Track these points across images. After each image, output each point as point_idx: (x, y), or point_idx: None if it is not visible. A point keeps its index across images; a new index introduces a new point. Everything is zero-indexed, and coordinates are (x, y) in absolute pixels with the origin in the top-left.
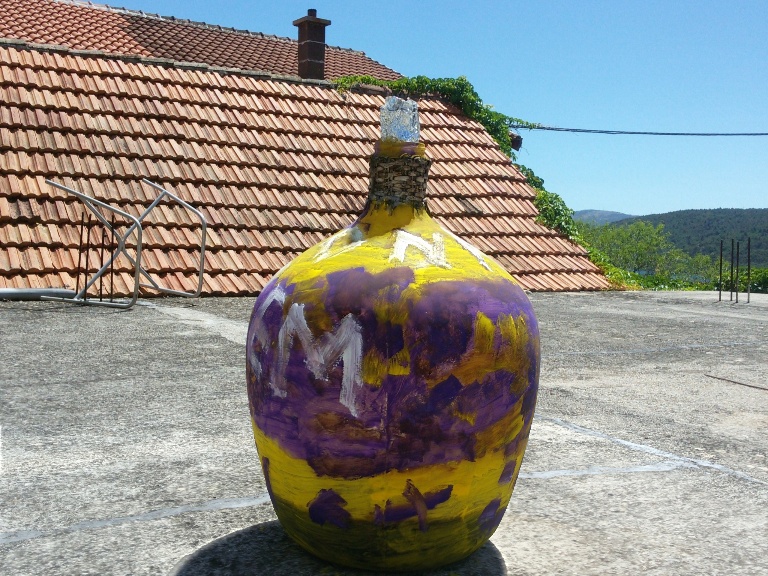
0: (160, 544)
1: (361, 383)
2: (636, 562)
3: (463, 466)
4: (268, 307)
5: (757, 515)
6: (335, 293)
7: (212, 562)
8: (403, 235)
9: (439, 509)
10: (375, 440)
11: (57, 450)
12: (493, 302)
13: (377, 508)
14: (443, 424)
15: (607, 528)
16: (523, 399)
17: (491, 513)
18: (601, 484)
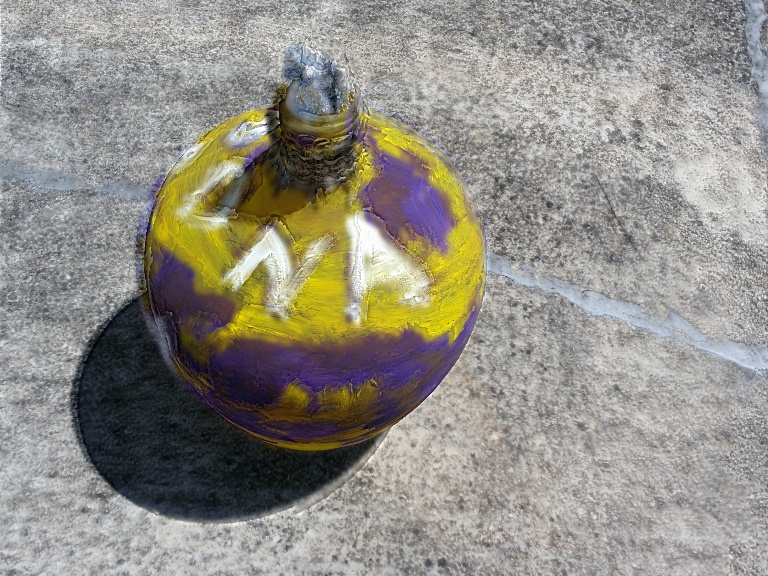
0: None
1: (181, 364)
2: (484, 525)
3: None
4: None
5: (716, 520)
6: (168, 280)
7: None
8: (277, 232)
9: None
10: None
11: (201, 1)
12: (325, 372)
13: None
14: None
15: (530, 451)
16: (367, 424)
17: None
18: (633, 359)
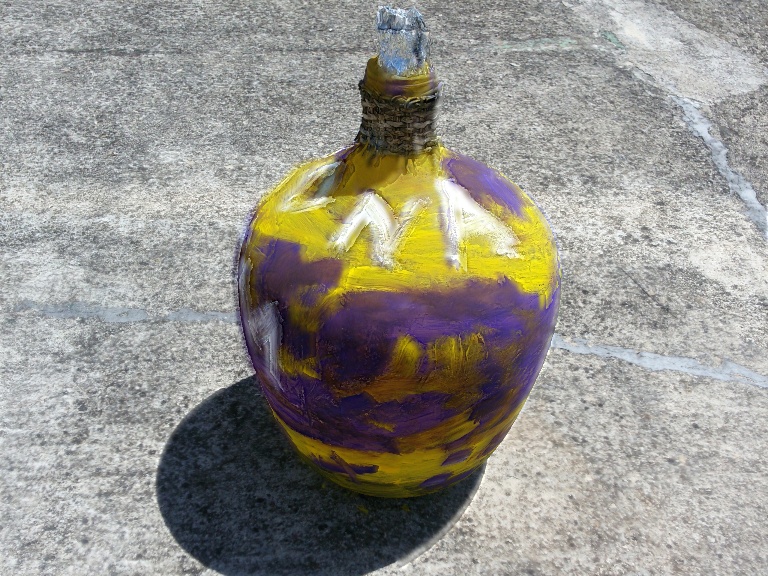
0: (214, 365)
1: (283, 368)
2: (600, 559)
3: (387, 456)
4: (244, 240)
5: None
6: (272, 271)
7: (231, 407)
8: (374, 203)
9: (368, 476)
10: (300, 414)
11: (238, 181)
12: (434, 323)
13: (313, 455)
14: (358, 426)
15: (628, 488)
16: (473, 409)
17: (439, 480)
18: (704, 401)
